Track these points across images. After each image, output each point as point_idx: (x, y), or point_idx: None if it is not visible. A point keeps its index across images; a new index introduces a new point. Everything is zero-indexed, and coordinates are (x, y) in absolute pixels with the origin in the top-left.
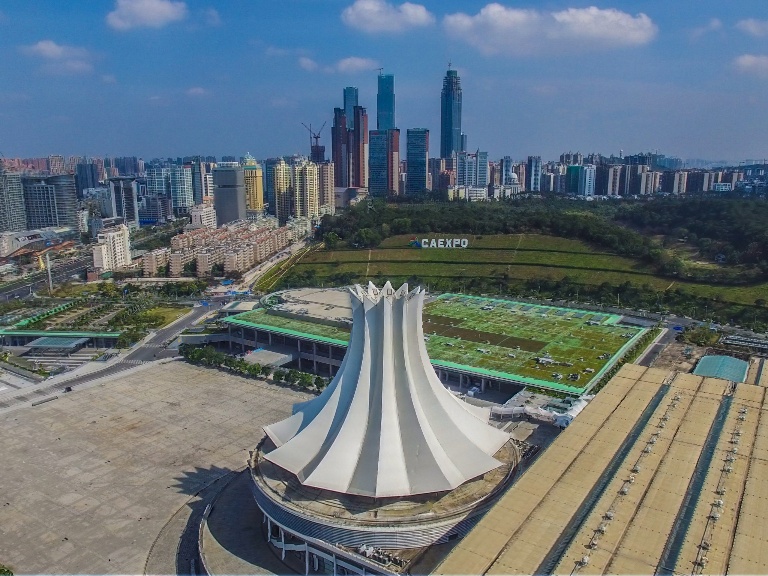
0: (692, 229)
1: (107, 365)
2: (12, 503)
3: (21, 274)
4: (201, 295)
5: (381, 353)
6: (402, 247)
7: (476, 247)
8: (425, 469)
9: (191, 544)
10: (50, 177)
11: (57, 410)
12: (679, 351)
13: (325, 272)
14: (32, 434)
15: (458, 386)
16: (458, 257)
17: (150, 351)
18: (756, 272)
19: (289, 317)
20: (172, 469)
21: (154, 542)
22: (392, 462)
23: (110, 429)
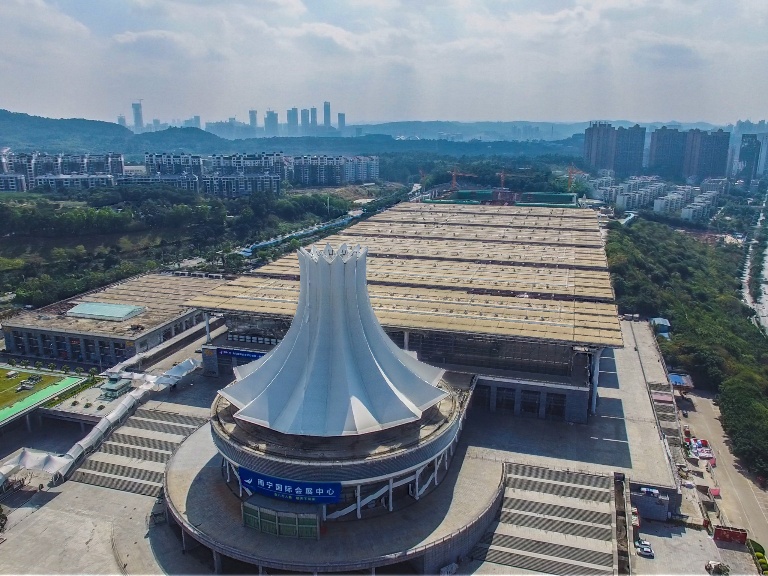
0: None
1: None
2: None
3: None
4: None
5: None
6: None
7: None
8: None
9: None
10: None
11: None
12: (39, 320)
13: None
14: None
15: None
16: None
17: None
18: None
19: None
20: None
21: None
22: None
23: None
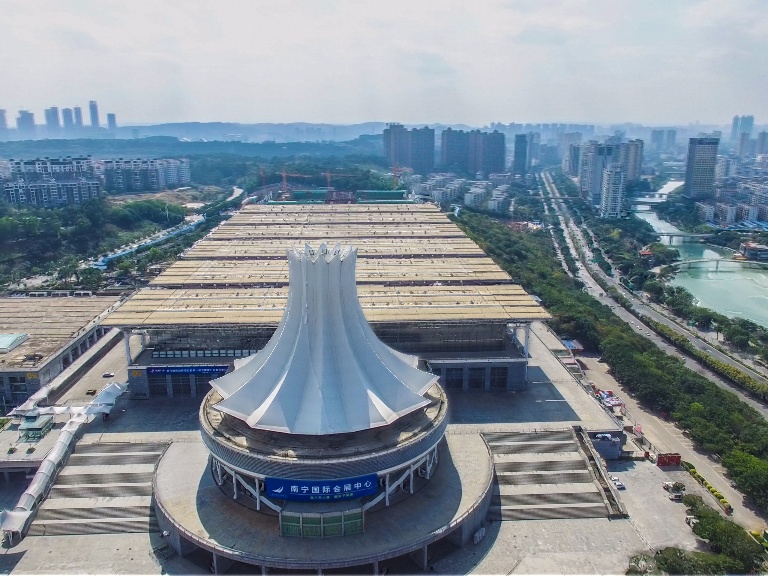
0: None
1: None
2: None
3: None
4: None
5: None
6: None
7: None
8: None
9: (458, 567)
10: None
11: None
12: None
13: None
14: None
15: None
16: None
17: None
18: None
19: None
20: None
21: None
22: None
23: None
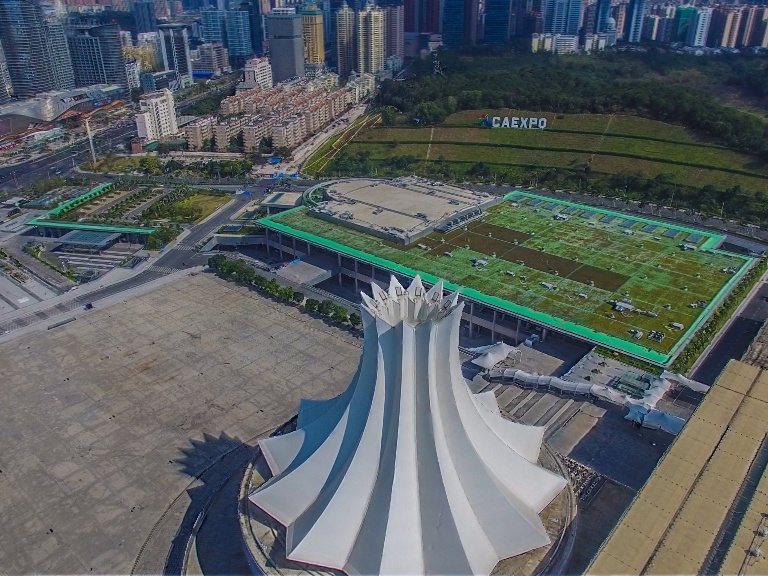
0: None
1: (134, 273)
2: (5, 471)
3: (68, 141)
4: (246, 177)
5: (398, 389)
6: (469, 125)
7: (556, 129)
8: (446, 549)
9: (182, 554)
10: (93, 27)
11: (72, 337)
12: None
13: (381, 154)
14: (41, 370)
15: (515, 330)
16: (533, 141)
17: (181, 255)
18: None
19: (331, 221)
20: (178, 434)
21: (143, 546)
22: (404, 533)
23: (122, 369)
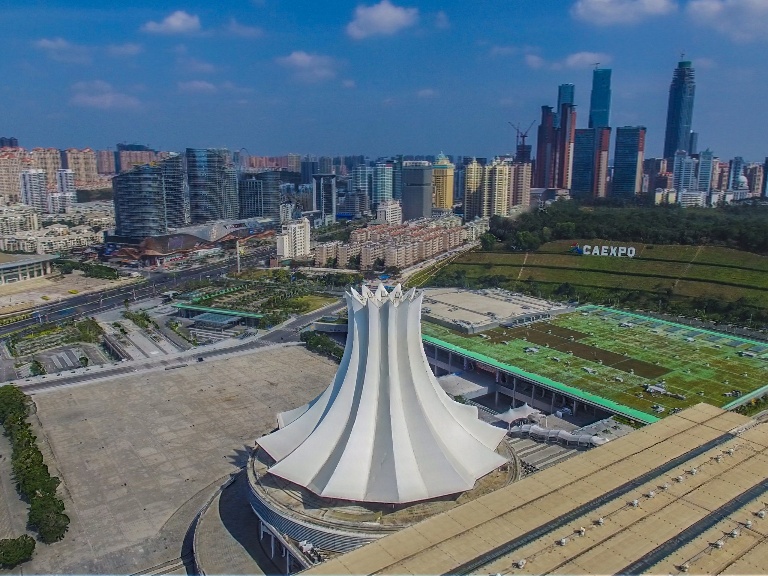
0: None
1: (242, 342)
2: (106, 447)
3: (223, 257)
4: (355, 287)
5: (366, 355)
6: (561, 253)
7: (644, 257)
8: (384, 478)
9: None
10: (260, 173)
11: (181, 376)
12: None
13: (476, 273)
14: (152, 393)
15: (550, 404)
16: (621, 267)
17: (283, 334)
18: None
19: None
20: (237, 441)
21: (186, 502)
22: (357, 465)
23: (210, 398)
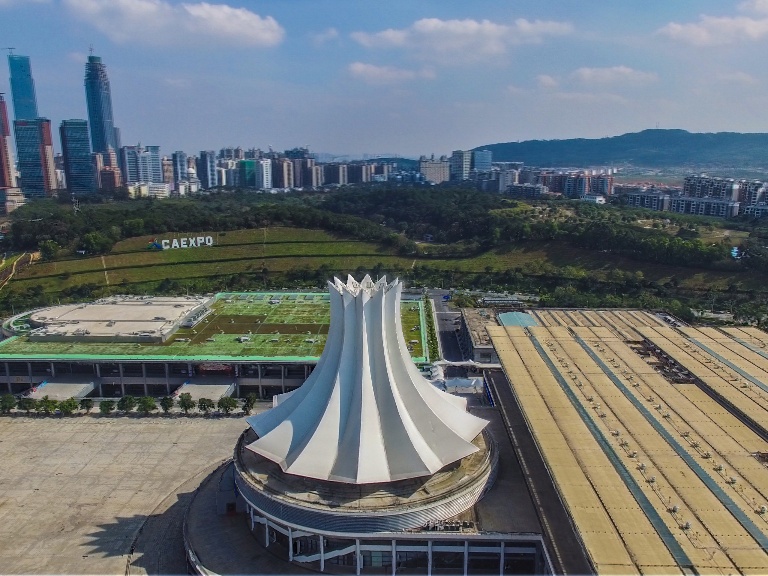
0: (387, 215)
1: None
2: None
3: None
4: None
5: (380, 343)
6: (140, 250)
7: (222, 244)
8: (446, 440)
9: None
10: None
11: None
12: (477, 314)
13: (53, 287)
14: None
15: (303, 378)
16: (207, 256)
17: None
18: (476, 245)
19: (65, 341)
20: (68, 537)
21: None
22: (416, 442)
23: None
